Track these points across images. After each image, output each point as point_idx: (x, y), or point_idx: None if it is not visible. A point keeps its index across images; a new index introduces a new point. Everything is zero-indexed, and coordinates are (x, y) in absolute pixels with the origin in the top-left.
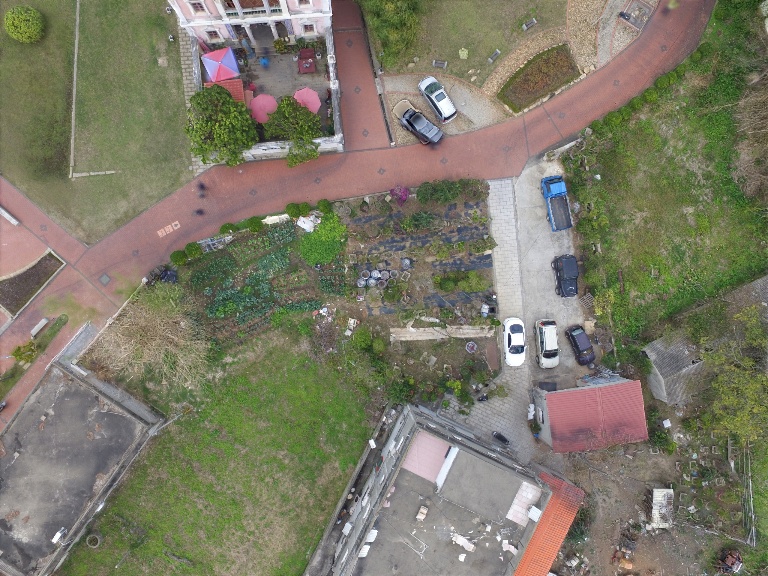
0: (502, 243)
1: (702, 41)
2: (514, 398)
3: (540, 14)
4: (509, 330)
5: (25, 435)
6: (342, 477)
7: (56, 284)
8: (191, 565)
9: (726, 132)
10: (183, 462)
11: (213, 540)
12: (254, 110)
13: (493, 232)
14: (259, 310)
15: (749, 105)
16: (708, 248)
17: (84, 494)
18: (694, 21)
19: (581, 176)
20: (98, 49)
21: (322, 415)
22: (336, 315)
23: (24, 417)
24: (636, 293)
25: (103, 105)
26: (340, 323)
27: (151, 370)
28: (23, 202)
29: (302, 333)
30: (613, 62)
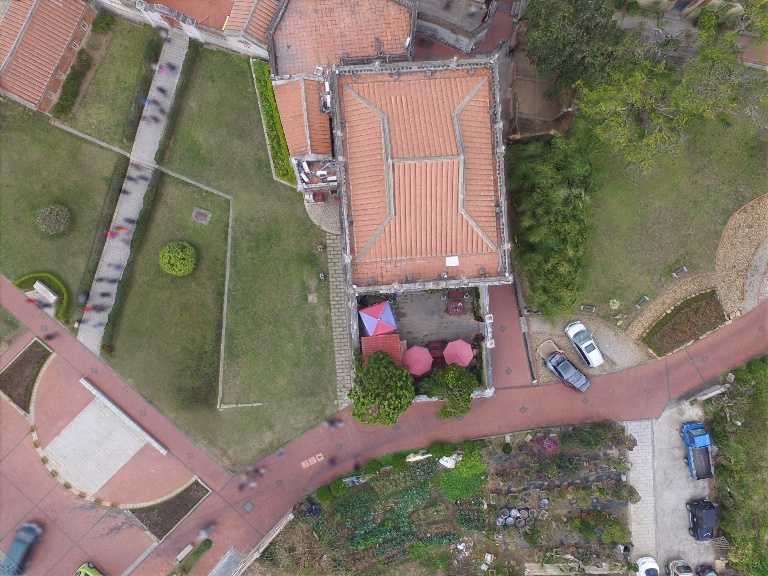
0: (639, 483)
1: None
2: None
3: (689, 260)
4: (645, 574)
5: None
6: None
7: (201, 510)
8: None
9: None
10: None
11: None
12: (409, 363)
13: (630, 472)
14: (398, 542)
15: None
16: None
17: None
18: None
19: (724, 427)
20: (249, 283)
21: None
22: (473, 549)
23: None
24: None
25: (252, 339)
26: (477, 557)
27: None
28: (171, 430)
29: (440, 566)
30: (759, 308)
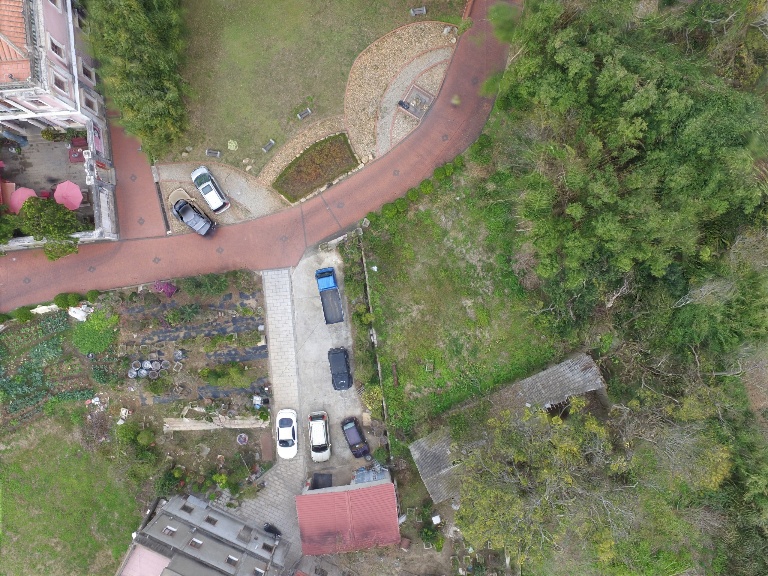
0: (278, 334)
1: (485, 130)
2: (288, 489)
3: (317, 103)
4: (278, 424)
5: None
6: (115, 565)
7: None
8: None
9: (504, 225)
10: None
11: None
12: (13, 204)
13: (269, 322)
14: (32, 398)
15: (528, 198)
16: (488, 341)
17: None
18: (476, 110)
19: None
20: None
21: (94, 504)
22: (109, 404)
23: None
24: (412, 386)
25: None
26: (113, 412)
27: None
28: None
29: (74, 422)
30: (393, 151)
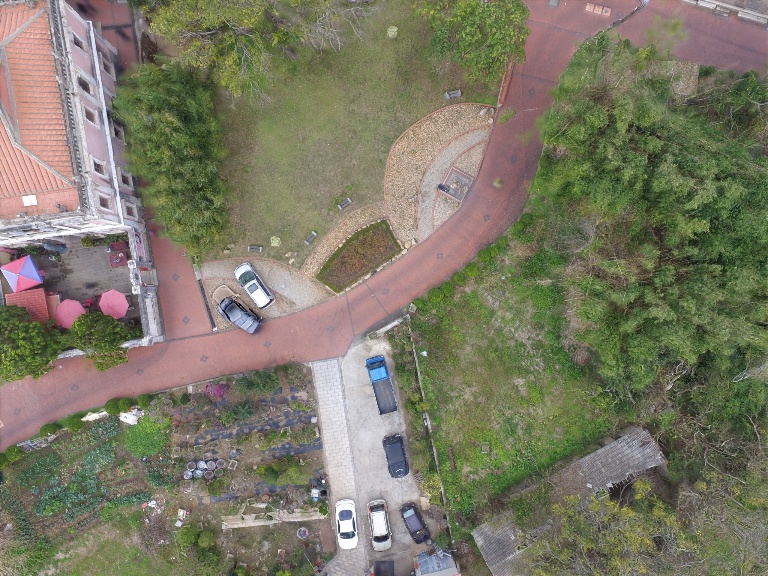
0: (331, 424)
1: (526, 208)
2: None
3: (356, 191)
4: (338, 516)
5: None
6: None
7: None
8: None
9: (552, 303)
10: None
11: None
12: (59, 317)
13: (321, 414)
14: (87, 506)
15: (575, 274)
16: (542, 418)
17: None
18: (516, 188)
19: (403, 358)
20: None
21: None
22: (166, 506)
23: None
24: (469, 469)
25: None
26: (170, 514)
27: None
28: None
29: (132, 527)
30: (435, 235)
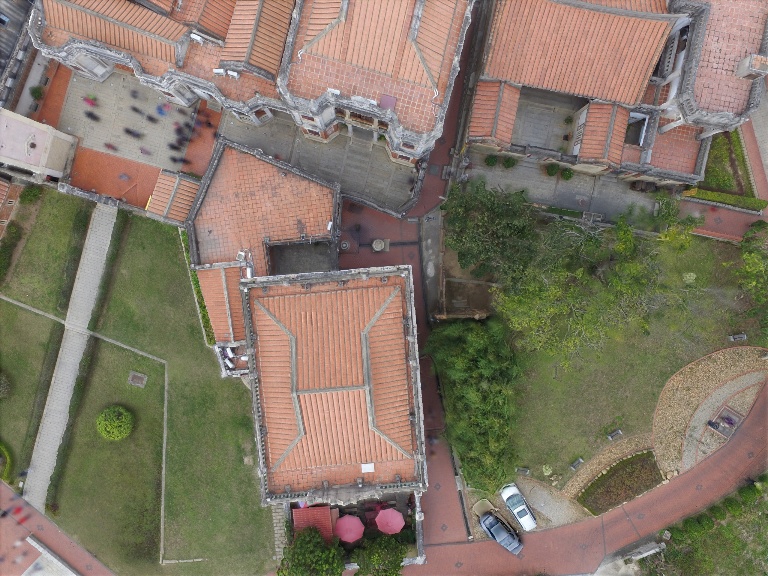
0: None
1: None
2: None
3: (626, 422)
4: None
5: None
6: None
7: None
8: None
9: None
10: None
11: None
12: (340, 532)
13: None
14: None
15: None
16: None
17: None
18: None
19: None
20: (186, 446)
21: None
22: None
23: None
24: None
25: (191, 499)
26: None
27: None
28: None
29: None
30: (697, 467)
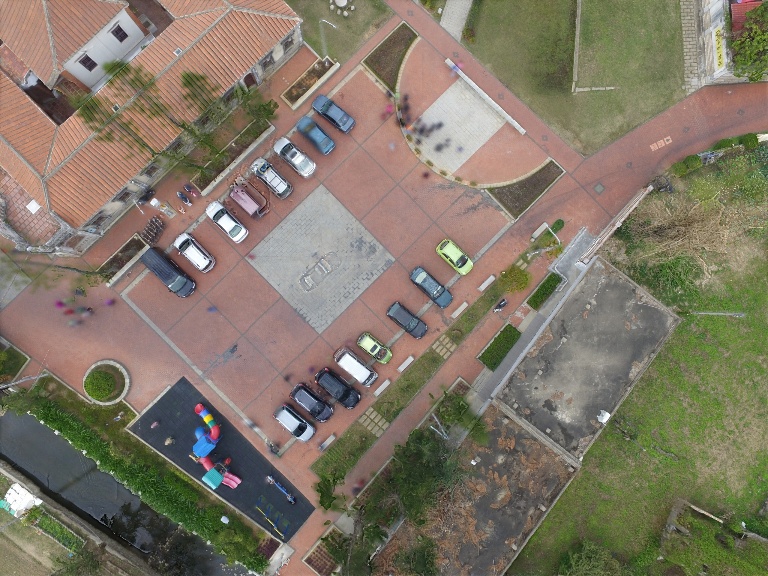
0: None
1: None
2: None
3: None
4: None
5: (570, 322)
6: None
7: (554, 191)
8: (677, 459)
9: None
10: (671, 362)
11: (697, 437)
12: None
13: None
14: (744, 222)
15: None
16: None
17: (620, 380)
18: None
19: None
20: None
21: None
22: None
23: (570, 305)
24: None
25: (606, 25)
26: None
27: (646, 274)
28: (527, 113)
29: None
30: None
